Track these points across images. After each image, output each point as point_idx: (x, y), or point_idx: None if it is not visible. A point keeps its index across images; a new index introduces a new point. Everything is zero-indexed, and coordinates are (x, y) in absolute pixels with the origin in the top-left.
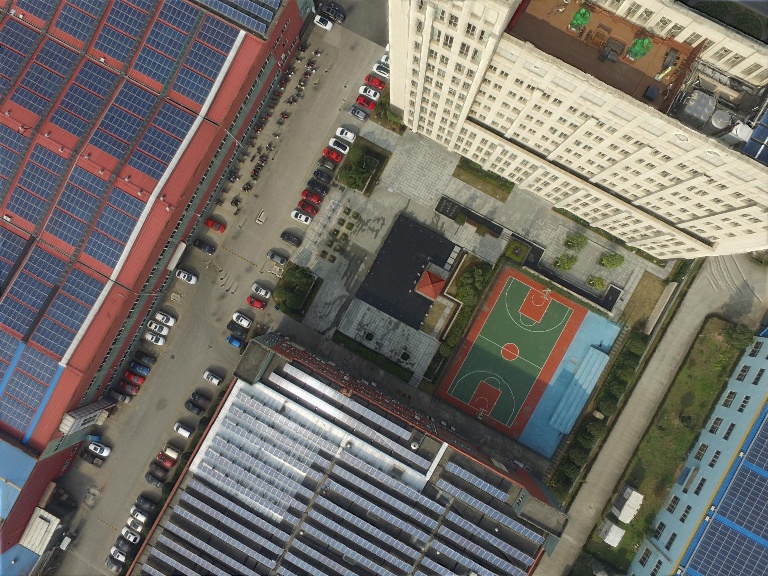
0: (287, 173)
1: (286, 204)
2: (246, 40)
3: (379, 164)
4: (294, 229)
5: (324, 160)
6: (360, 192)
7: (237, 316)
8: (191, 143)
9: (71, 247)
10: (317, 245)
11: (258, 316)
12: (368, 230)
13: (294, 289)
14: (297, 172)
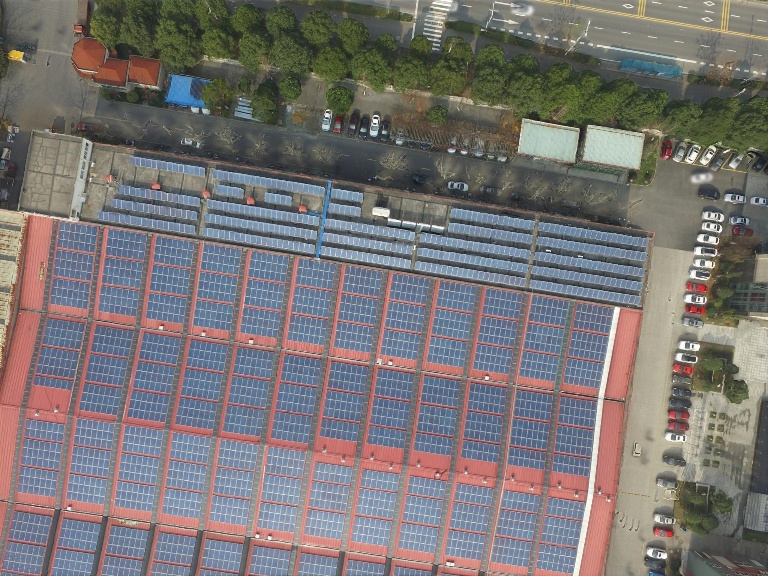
0: (645, 399)
1: (655, 429)
2: (621, 314)
3: (728, 362)
4: (671, 449)
5: (680, 377)
6: (719, 393)
7: (653, 552)
8: (601, 427)
9: (522, 568)
10: (698, 457)
11: (667, 543)
12: (738, 425)
13: (693, 506)
14: (654, 395)
